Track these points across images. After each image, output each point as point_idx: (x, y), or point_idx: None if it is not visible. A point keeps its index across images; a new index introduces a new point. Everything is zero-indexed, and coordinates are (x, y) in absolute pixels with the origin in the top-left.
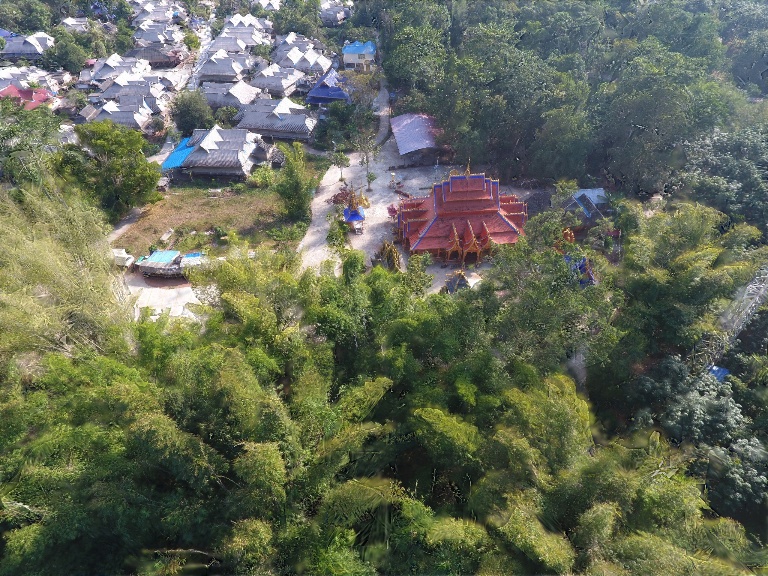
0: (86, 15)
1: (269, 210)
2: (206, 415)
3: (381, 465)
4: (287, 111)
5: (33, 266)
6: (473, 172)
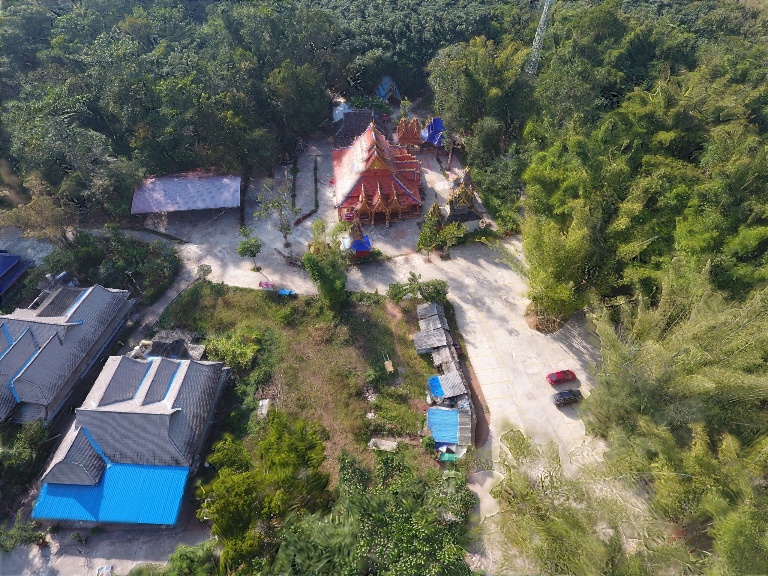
0: None
1: (326, 330)
2: (745, 197)
3: None
4: None
5: None
6: None
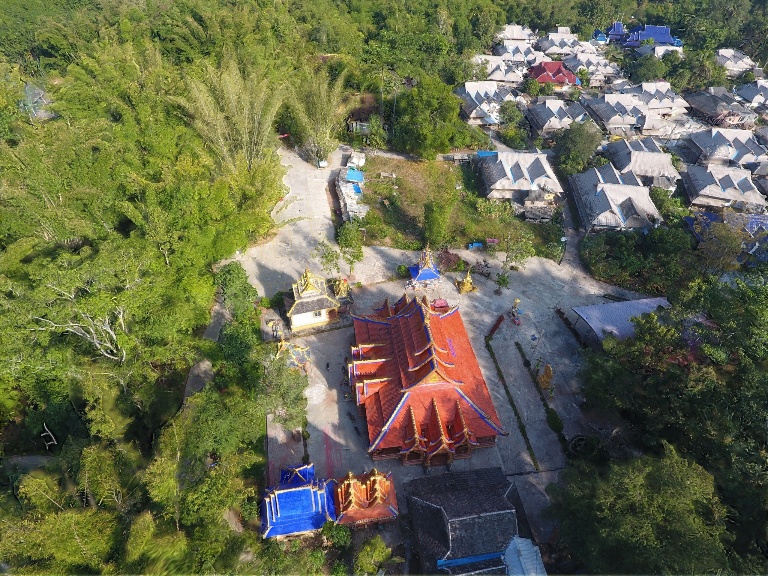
0: (754, 54)
1: None
2: None
3: (46, 253)
4: (621, 197)
5: None
6: (593, 415)
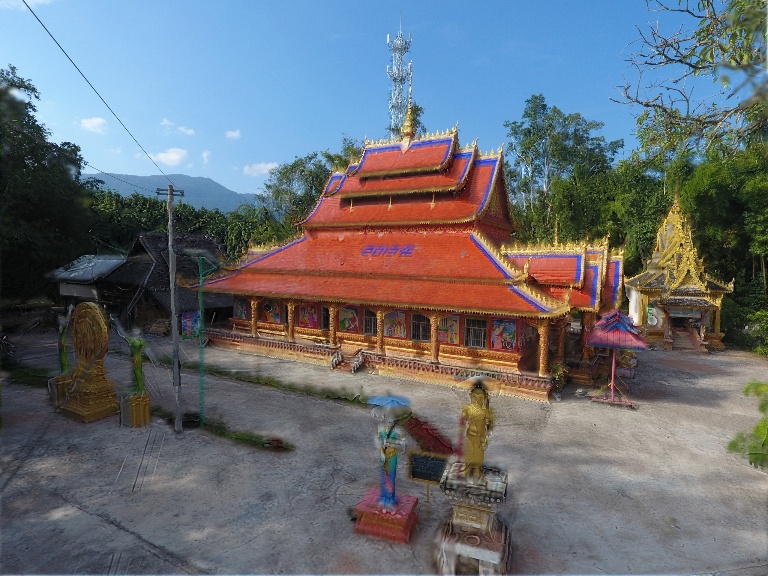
0: None
1: None
2: None
3: None
4: None
5: None
6: None
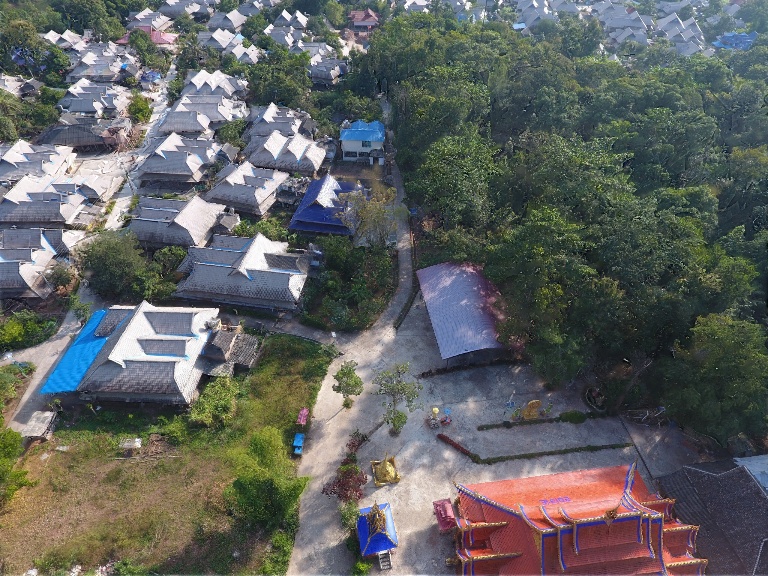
0: (3, 69)
1: (222, 500)
2: None
3: None
4: (261, 260)
5: None
6: None
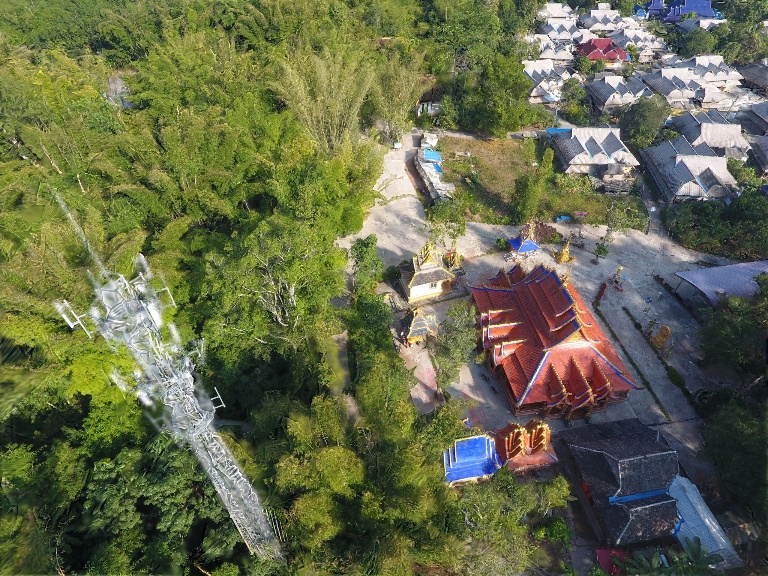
0: None
1: None
2: None
3: (186, 233)
4: (700, 168)
5: (316, 71)
6: (711, 371)
